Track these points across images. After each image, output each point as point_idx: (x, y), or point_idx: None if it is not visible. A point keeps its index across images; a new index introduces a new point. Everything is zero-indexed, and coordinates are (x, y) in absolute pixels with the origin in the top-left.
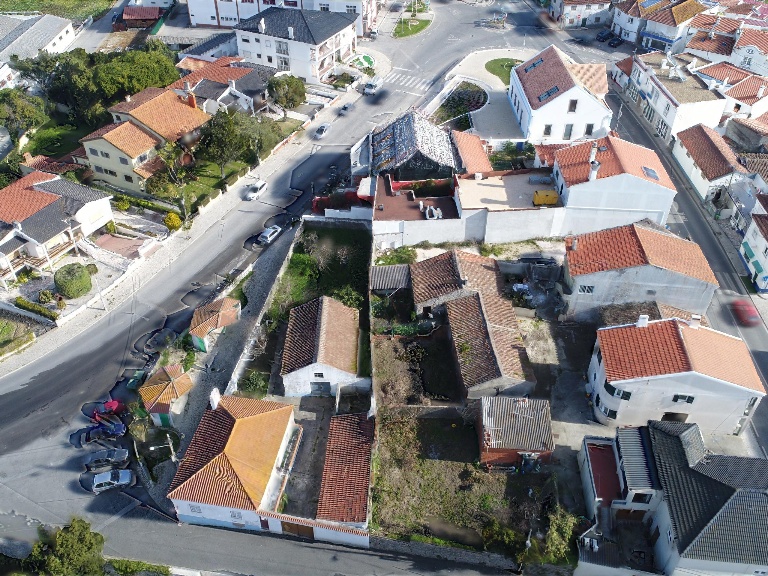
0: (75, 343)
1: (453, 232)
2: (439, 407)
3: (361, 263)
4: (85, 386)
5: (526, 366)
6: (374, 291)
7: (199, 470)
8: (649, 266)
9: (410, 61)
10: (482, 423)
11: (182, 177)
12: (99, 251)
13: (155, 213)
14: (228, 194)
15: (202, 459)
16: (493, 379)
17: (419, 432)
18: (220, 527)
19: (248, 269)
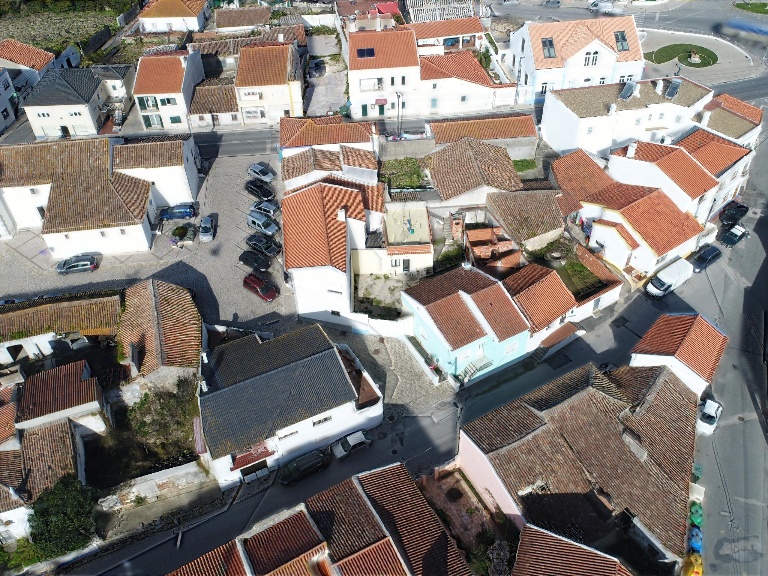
0: None
1: None
2: None
3: None
4: None
5: (201, 56)
6: None
7: None
8: None
9: (679, 17)
10: None
11: None
12: None
13: None
14: None
15: None
16: None
17: None
18: None
19: (329, 6)
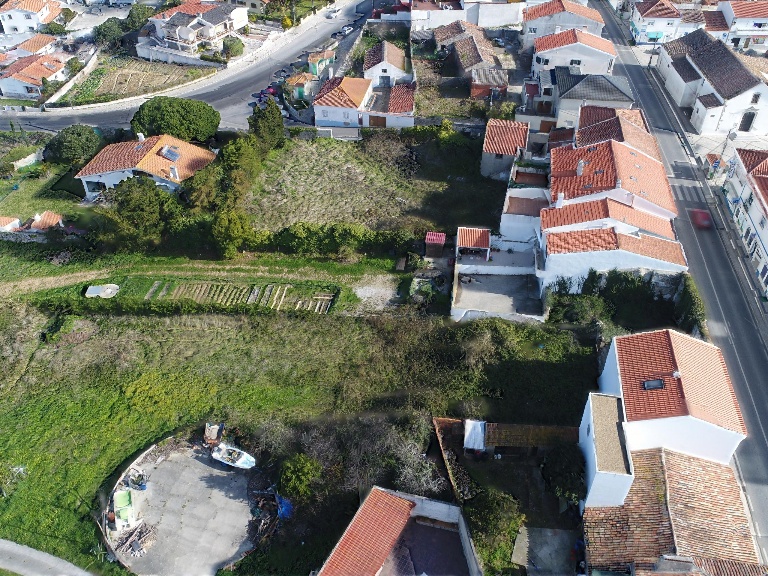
0: (240, 74)
1: None
2: (450, 78)
3: (404, 39)
4: (251, 88)
5: (497, 61)
6: (413, 41)
7: (328, 93)
8: (566, 12)
9: None
10: (472, 77)
11: (288, 5)
12: (243, 38)
13: (273, 22)
14: (317, 15)
15: (328, 91)
16: (479, 63)
17: (439, 90)
18: (337, 127)
19: (336, 44)
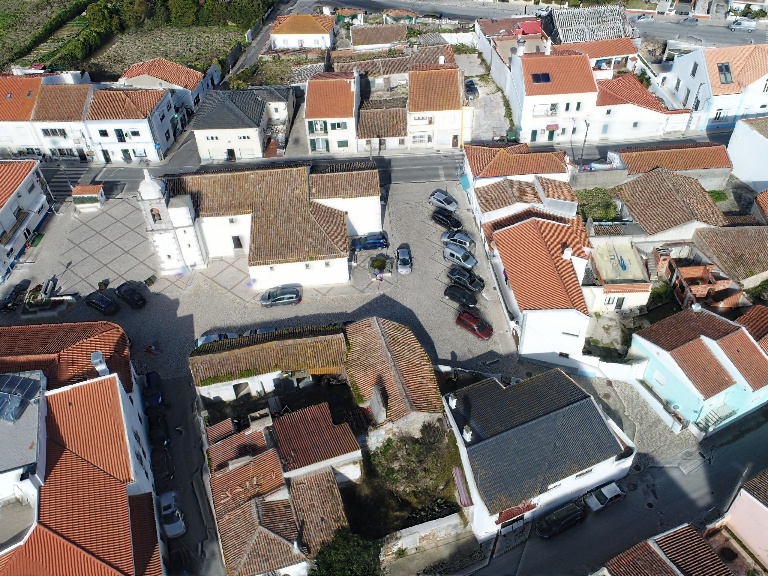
0: (390, 0)
1: None
2: None
3: None
4: (361, 8)
5: None
6: None
7: None
8: None
9: None
10: None
11: None
12: None
13: None
14: (537, 6)
15: None
16: None
17: None
18: None
19: (456, 22)
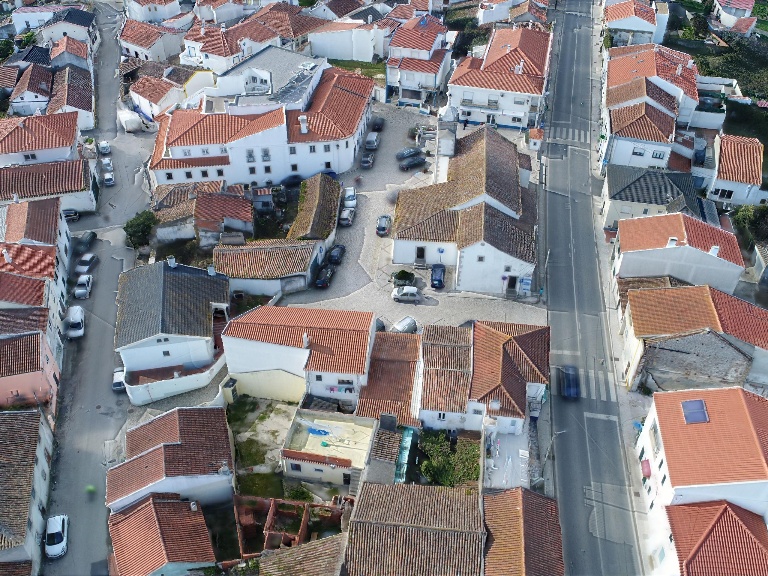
0: None
1: None
2: None
3: None
4: None
5: None
6: None
7: None
8: None
9: None
10: None
11: None
12: None
13: None
14: None
15: None
16: None
17: None
18: None
19: None
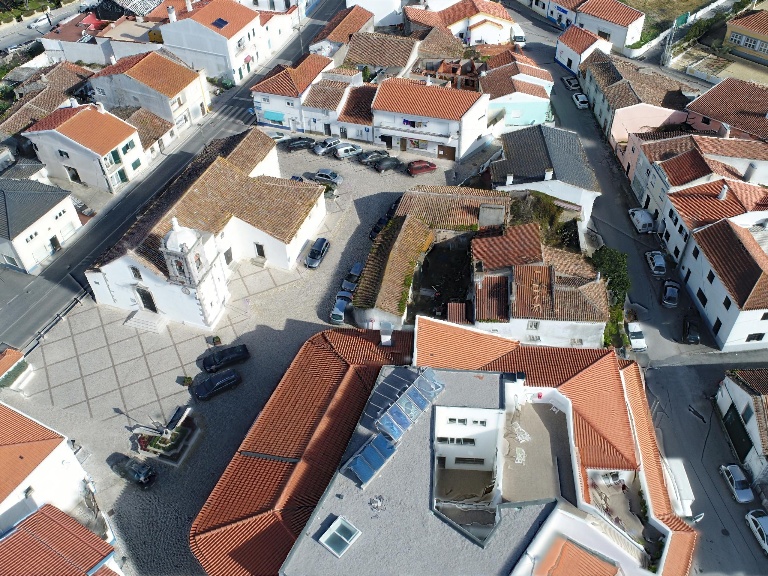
0: None
1: (97, 55)
2: None
3: None
4: None
5: None
6: (5, 81)
7: None
8: (122, 74)
9: None
10: None
11: None
12: None
13: None
14: (22, 22)
15: None
16: None
17: None
18: None
19: None
